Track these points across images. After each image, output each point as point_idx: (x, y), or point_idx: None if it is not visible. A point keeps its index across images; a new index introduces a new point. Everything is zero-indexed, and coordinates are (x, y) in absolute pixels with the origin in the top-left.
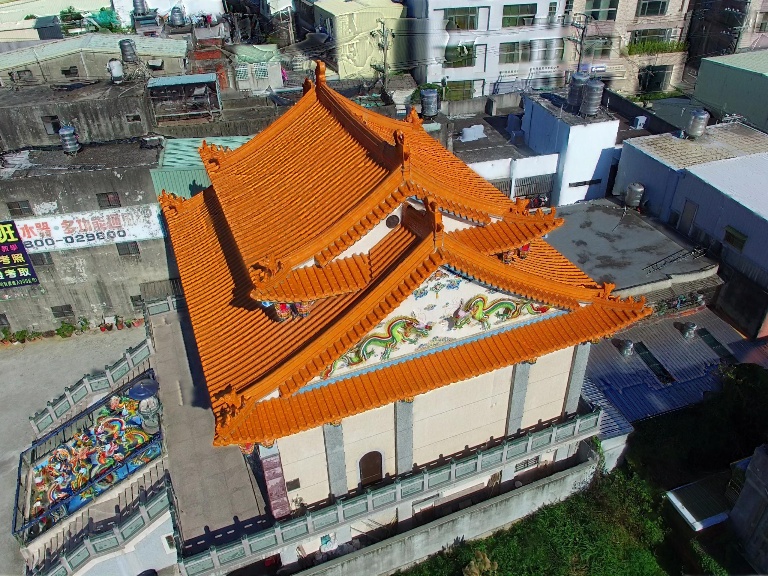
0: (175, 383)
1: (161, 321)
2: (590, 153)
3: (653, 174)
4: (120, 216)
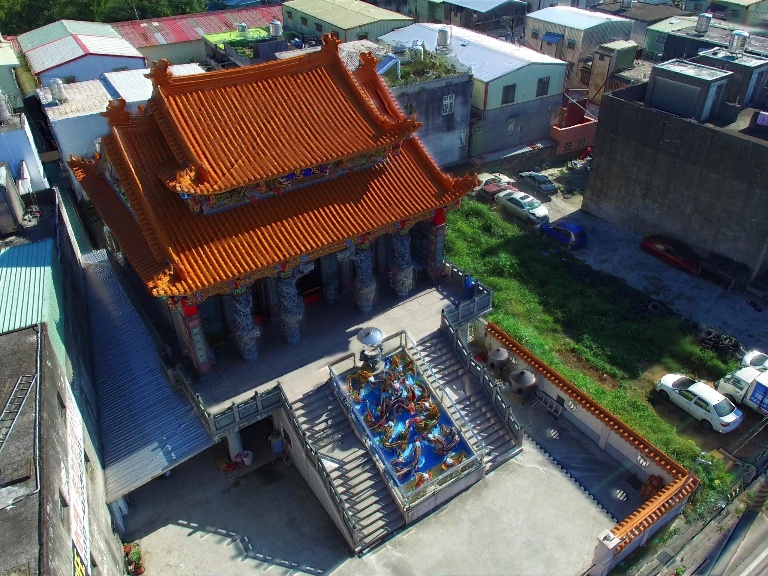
0: (322, 371)
1: None
2: (33, 149)
3: (102, 125)
4: (71, 423)
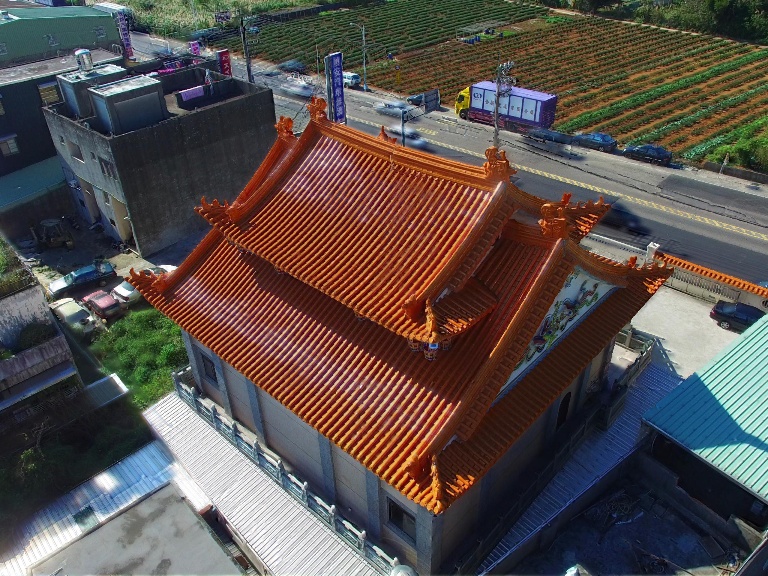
0: None
1: (631, 358)
2: None
3: None
4: None
